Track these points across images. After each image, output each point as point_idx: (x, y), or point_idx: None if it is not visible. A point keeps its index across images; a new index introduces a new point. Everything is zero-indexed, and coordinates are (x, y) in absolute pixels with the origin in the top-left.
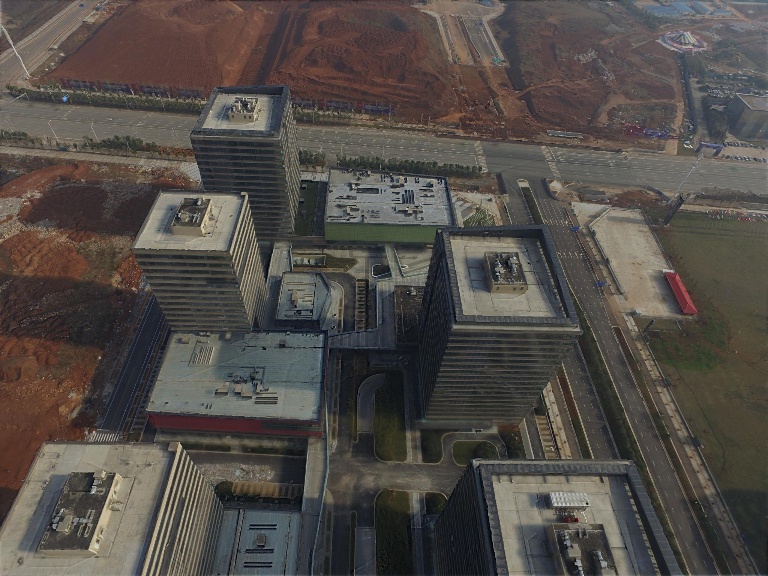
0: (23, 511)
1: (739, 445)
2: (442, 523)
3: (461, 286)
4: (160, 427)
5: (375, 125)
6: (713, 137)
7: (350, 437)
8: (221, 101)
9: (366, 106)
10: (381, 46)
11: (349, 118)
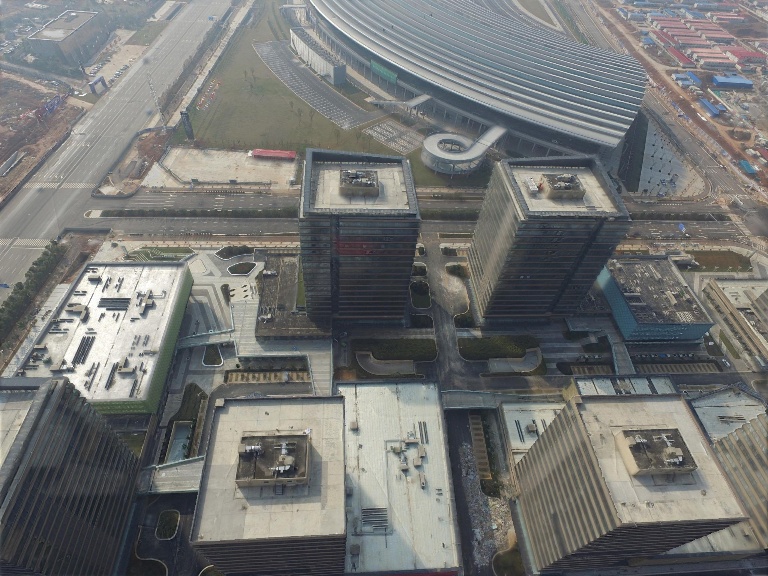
0: (676, 513)
1: None
2: (499, 296)
3: None
4: None
5: None
6: (78, 77)
7: None
8: None
9: None
10: None
11: None
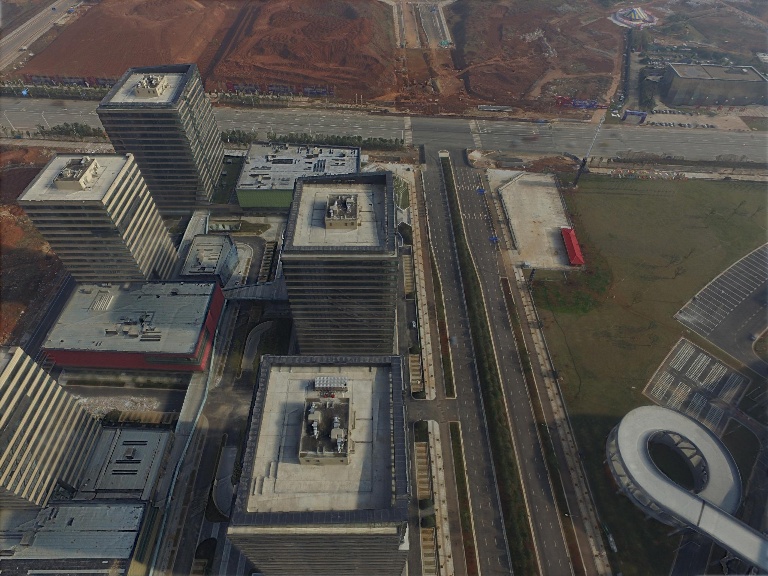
0: None
1: (596, 377)
2: None
3: (301, 224)
4: (60, 365)
5: (312, 106)
6: (642, 106)
7: (234, 374)
8: (133, 80)
9: (305, 89)
10: (326, 33)
11: (287, 100)
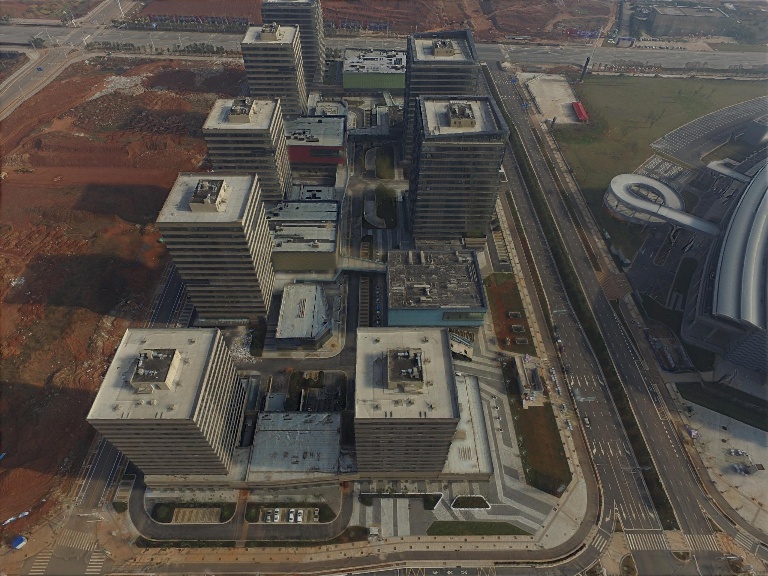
0: None
1: (597, 172)
2: None
3: (418, 54)
4: None
5: (377, 36)
6: (632, 36)
7: (361, 171)
8: None
9: (370, 24)
10: None
11: (358, 31)
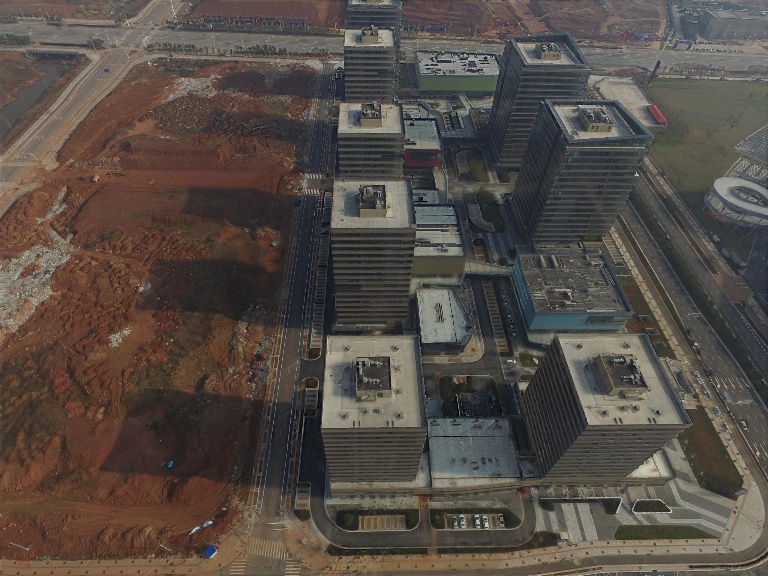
0: None
1: (689, 175)
2: (519, 178)
3: None
4: None
5: (435, 38)
6: (687, 39)
7: (455, 174)
8: None
9: (427, 26)
10: None
11: (416, 33)
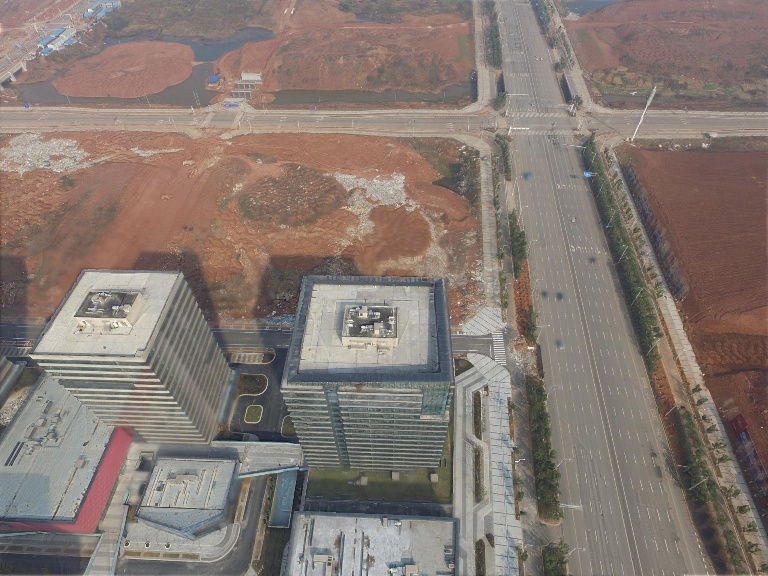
0: None
1: None
2: None
3: None
4: None
5: None
6: None
7: None
8: (409, 294)
9: None
10: None
11: (738, 575)
